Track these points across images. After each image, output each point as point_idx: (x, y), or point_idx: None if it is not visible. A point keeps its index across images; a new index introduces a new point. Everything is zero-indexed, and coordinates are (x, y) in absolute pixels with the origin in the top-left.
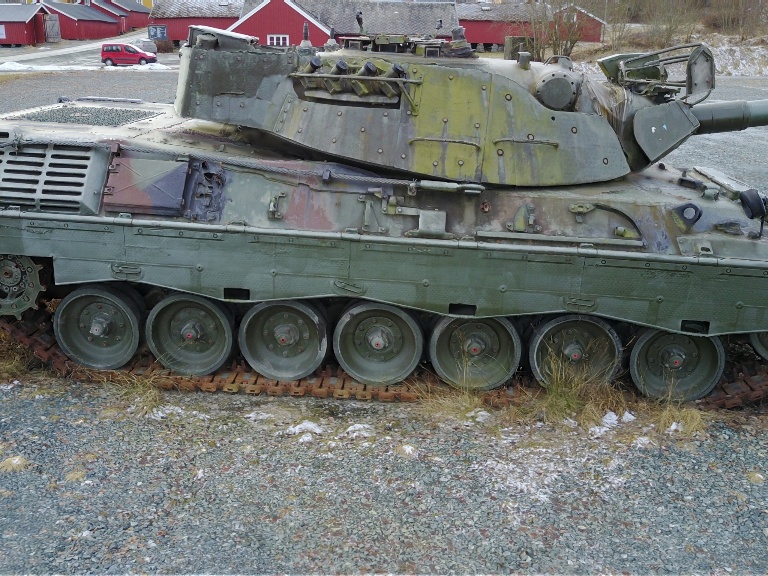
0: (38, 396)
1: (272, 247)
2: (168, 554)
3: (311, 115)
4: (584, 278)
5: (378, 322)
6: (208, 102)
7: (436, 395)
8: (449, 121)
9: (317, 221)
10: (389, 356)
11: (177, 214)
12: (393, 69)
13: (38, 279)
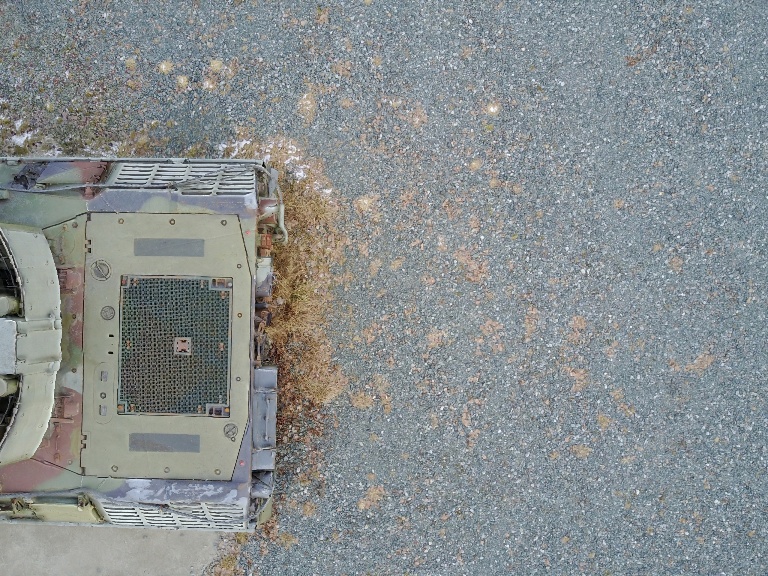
0: (191, 148)
1: None
2: (63, 4)
3: None
4: None
5: None
6: None
7: None
8: None
9: None
10: None
11: None
12: None
13: None
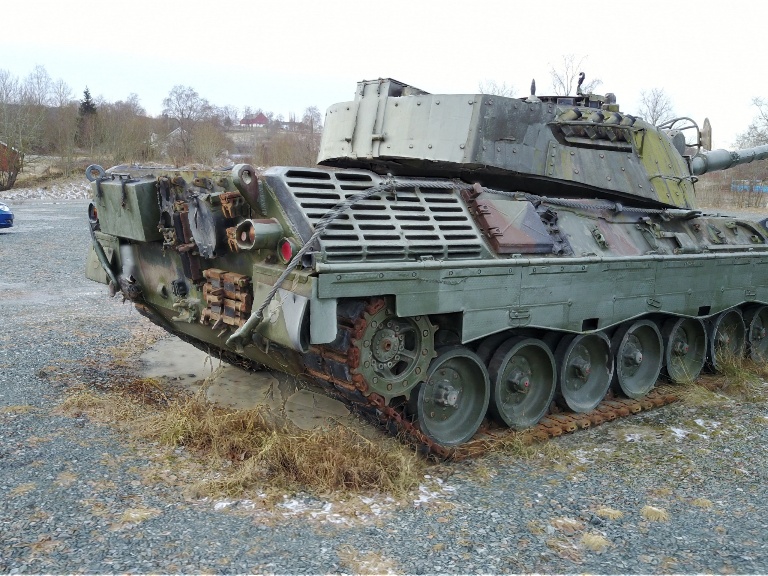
0: (490, 475)
1: (616, 274)
2: None
3: (580, 158)
4: (753, 274)
5: (630, 340)
6: (492, 147)
7: (683, 391)
8: (658, 163)
9: (627, 248)
10: (634, 370)
11: (550, 251)
12: (632, 119)
13: (433, 343)
